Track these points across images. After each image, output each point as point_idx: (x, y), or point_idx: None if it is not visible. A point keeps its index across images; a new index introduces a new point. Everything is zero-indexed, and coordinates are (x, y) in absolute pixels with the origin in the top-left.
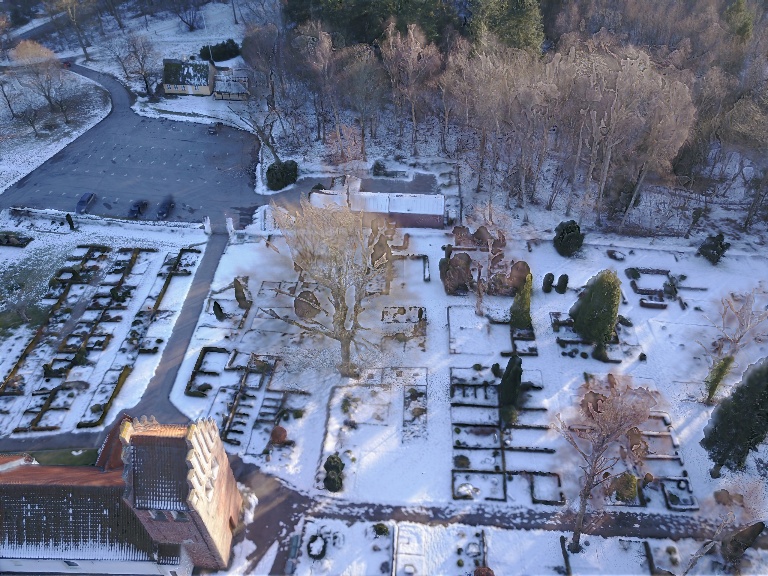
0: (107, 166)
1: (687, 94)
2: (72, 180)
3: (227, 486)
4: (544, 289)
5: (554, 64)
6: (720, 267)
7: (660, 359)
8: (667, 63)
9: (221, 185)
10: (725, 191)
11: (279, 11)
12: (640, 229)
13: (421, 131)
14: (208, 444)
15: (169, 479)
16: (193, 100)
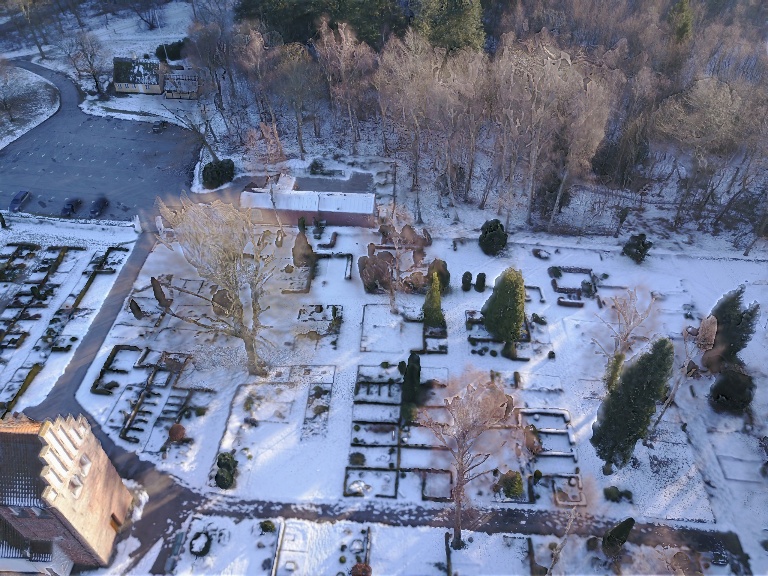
0: (47, 164)
1: (602, 94)
2: (10, 178)
3: (106, 483)
4: (463, 287)
5: (476, 63)
6: (644, 266)
7: (569, 357)
8: (601, 63)
9: (158, 184)
10: (660, 191)
11: (227, 10)
12: (570, 228)
13: (366, 130)
14: (74, 441)
15: (26, 476)
16: (143, 99)
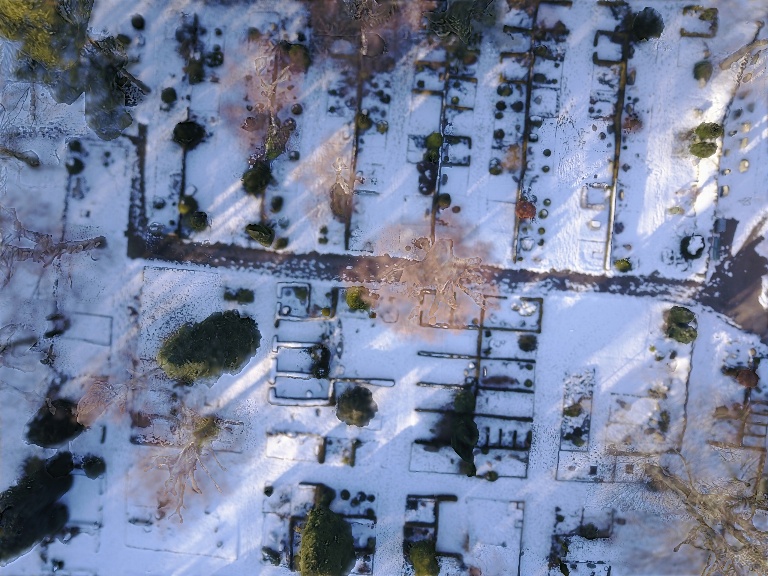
0: None
1: None
2: None
3: None
4: None
5: None
6: None
7: (245, 490)
8: None
9: None
10: None
11: None
12: None
13: None
14: None
15: None
16: None
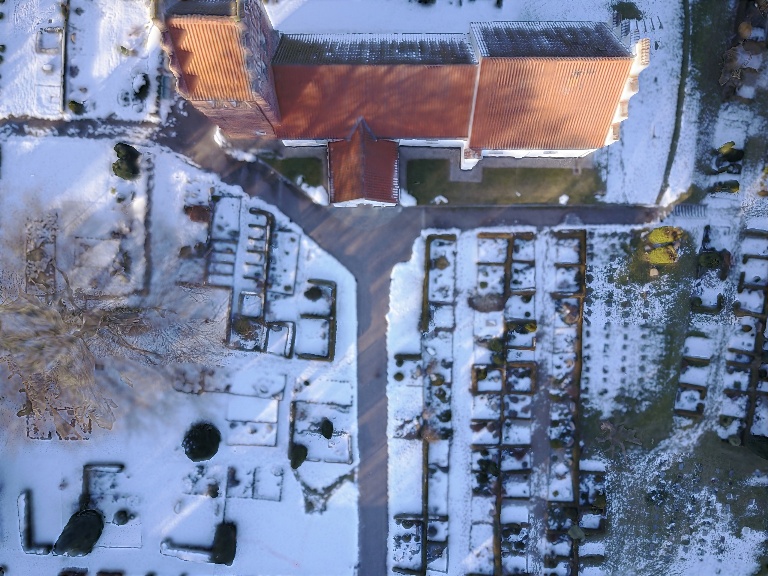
0: None
1: None
2: None
3: None
4: None
5: None
6: None
7: None
8: None
9: None
10: None
11: None
12: None
13: None
14: None
15: None
16: None
